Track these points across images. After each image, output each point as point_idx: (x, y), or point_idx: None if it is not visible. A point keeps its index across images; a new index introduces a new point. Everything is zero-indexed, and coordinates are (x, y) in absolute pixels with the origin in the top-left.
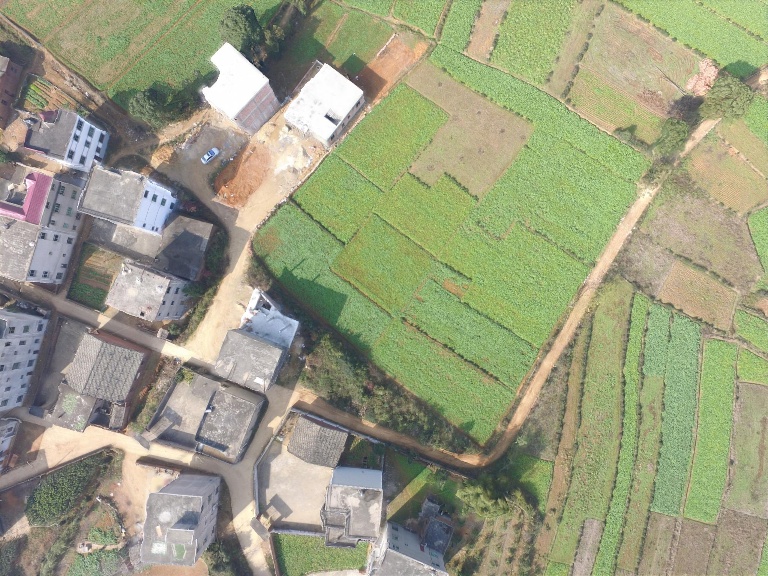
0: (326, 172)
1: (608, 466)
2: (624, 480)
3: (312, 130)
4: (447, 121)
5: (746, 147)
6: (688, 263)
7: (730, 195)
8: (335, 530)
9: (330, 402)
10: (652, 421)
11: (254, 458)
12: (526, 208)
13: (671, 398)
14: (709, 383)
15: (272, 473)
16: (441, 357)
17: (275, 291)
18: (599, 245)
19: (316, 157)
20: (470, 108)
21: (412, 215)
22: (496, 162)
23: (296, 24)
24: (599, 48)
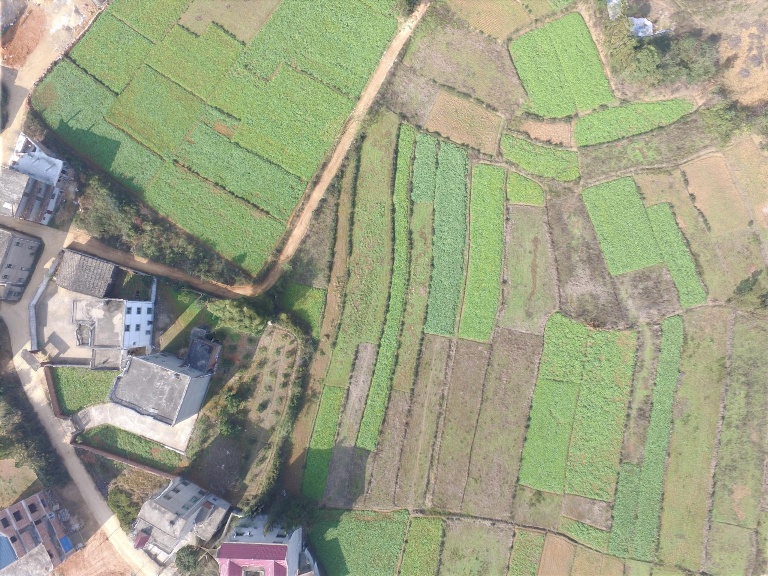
0: (99, 29)
1: (380, 291)
2: (396, 304)
3: None
4: None
5: None
6: (452, 92)
7: (489, 23)
8: (101, 355)
9: (102, 240)
10: (423, 246)
11: (31, 298)
12: (291, 49)
13: (441, 223)
14: (478, 206)
15: (49, 312)
16: (212, 195)
17: (50, 141)
18: (363, 79)
19: (89, 15)
20: None
21: (182, 63)
22: (261, 8)
23: None
24: None
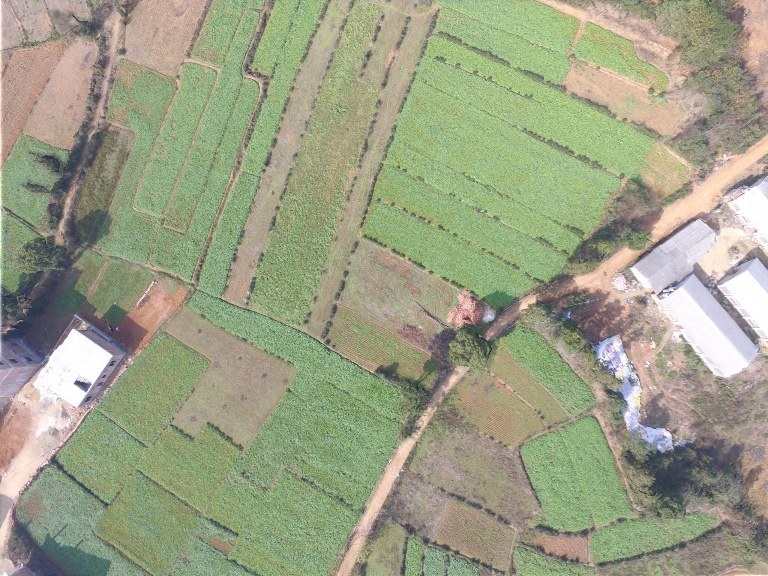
0: (88, 430)
1: None
2: None
3: (62, 398)
4: (208, 368)
5: (512, 378)
6: (461, 502)
7: (499, 428)
8: None
9: None
10: None
11: None
12: (291, 455)
13: None
14: None
15: None
16: None
17: (35, 563)
18: (367, 490)
19: (77, 416)
20: (231, 354)
21: (175, 470)
22: (259, 408)
23: (58, 275)
24: (356, 285)
